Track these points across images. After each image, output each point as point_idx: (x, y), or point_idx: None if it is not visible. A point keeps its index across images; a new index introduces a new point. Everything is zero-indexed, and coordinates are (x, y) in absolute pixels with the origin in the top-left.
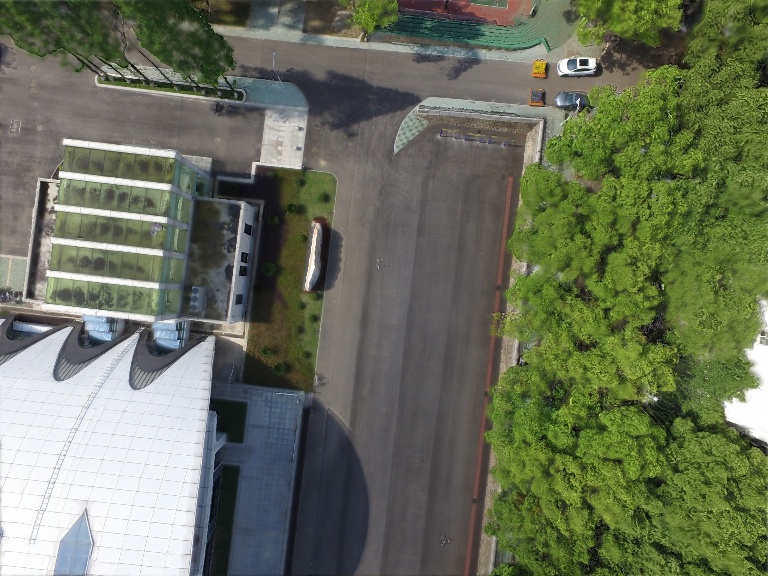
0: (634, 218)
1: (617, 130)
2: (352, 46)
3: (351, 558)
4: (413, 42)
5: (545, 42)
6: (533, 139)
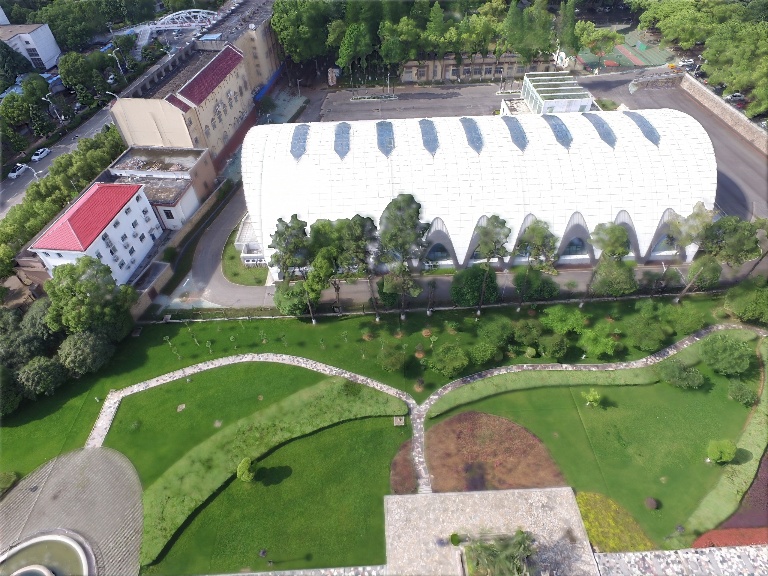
0: (756, 32)
1: (730, 24)
2: (593, 76)
3: (737, 192)
4: (617, 71)
5: (667, 63)
6: (685, 81)
